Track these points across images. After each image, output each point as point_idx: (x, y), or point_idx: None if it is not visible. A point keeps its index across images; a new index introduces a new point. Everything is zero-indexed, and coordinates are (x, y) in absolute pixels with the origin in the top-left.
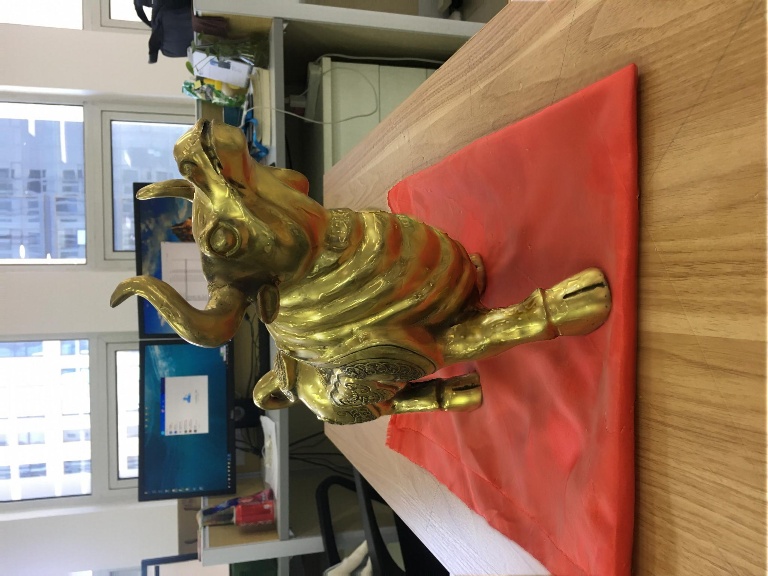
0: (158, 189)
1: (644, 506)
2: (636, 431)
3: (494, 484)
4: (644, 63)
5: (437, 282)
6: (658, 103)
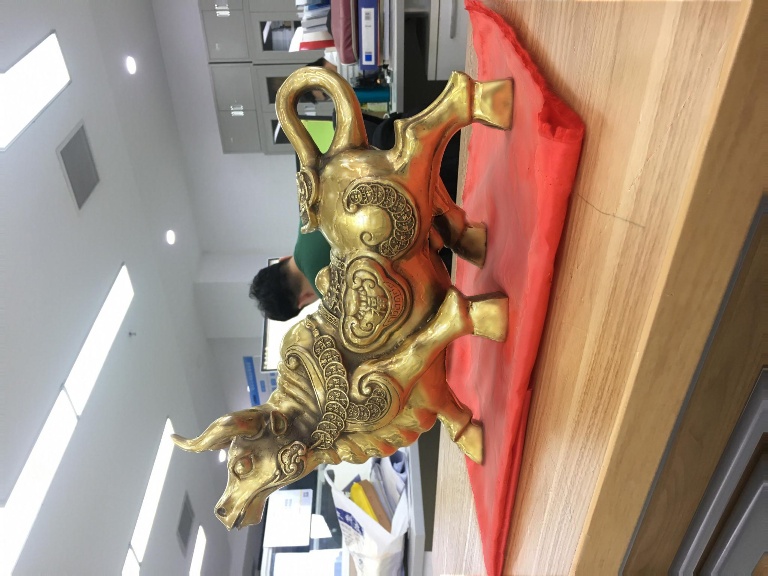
0: None
1: None
2: None
3: None
4: None
5: None
6: None
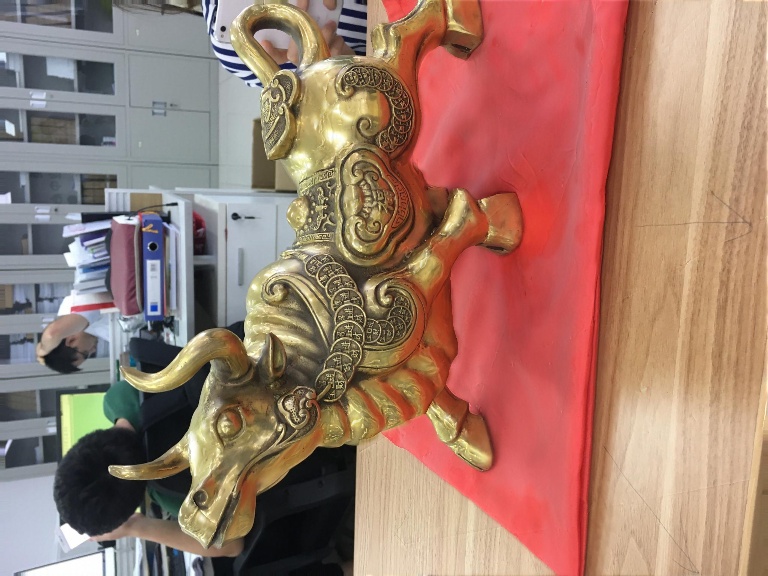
0: None
1: None
2: None
3: None
4: None
5: None
6: None
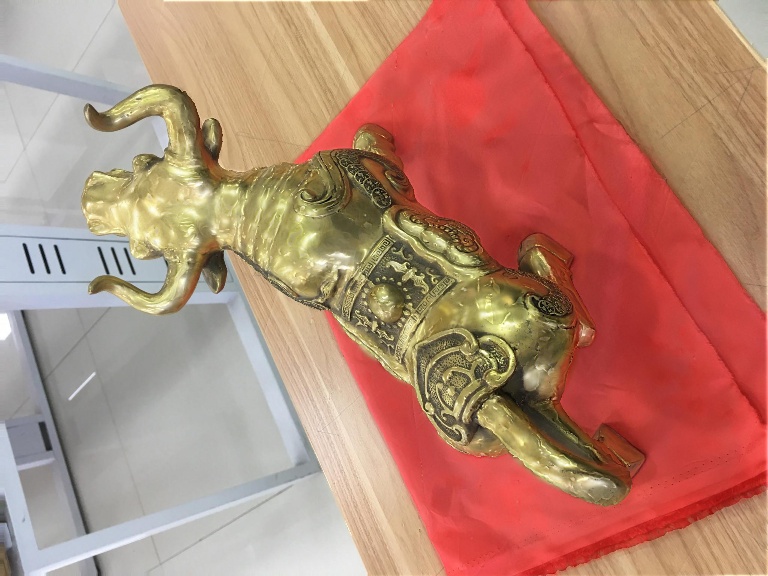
0: None
1: None
2: None
3: (582, 152)
4: None
5: None
6: None
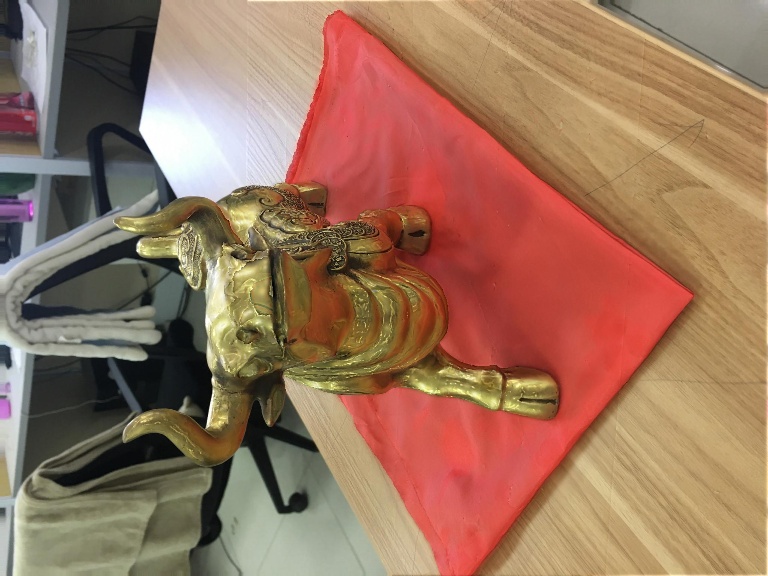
0: (150, 229)
1: (507, 541)
2: (527, 505)
3: (370, 403)
4: (700, 294)
5: (421, 356)
6: (690, 340)
